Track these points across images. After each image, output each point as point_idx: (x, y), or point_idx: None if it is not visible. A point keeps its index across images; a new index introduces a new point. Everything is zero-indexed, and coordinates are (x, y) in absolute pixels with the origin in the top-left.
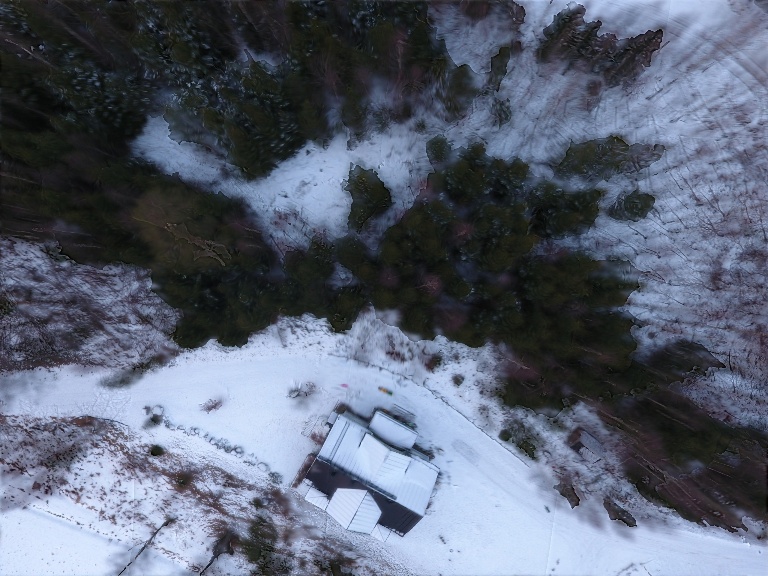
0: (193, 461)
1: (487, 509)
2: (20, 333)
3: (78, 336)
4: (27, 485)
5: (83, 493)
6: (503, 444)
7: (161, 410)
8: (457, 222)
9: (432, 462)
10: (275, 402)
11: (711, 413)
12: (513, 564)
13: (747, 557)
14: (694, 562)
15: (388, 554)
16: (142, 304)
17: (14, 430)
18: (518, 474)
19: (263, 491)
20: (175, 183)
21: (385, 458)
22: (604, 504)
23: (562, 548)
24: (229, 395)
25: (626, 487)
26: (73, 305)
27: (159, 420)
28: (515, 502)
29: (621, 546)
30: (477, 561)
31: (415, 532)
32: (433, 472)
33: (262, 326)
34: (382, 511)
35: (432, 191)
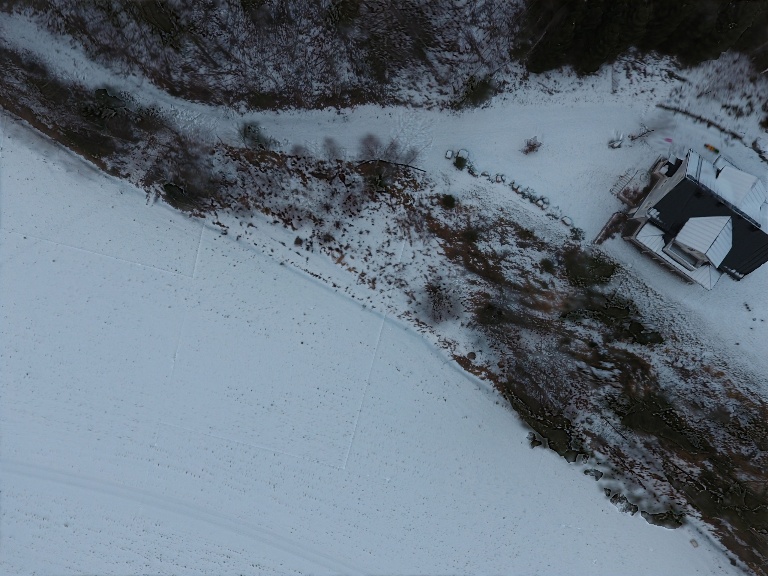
0: (486, 215)
1: None
2: (328, 59)
3: (391, 66)
4: (289, 239)
5: (348, 251)
6: None
7: (467, 154)
8: None
9: None
10: (592, 152)
11: None
12: None
13: None
14: None
15: (682, 321)
16: (479, 27)
17: (289, 176)
18: None
19: (555, 252)
20: None
21: (753, 185)
22: None
23: None
24: (543, 142)
25: None
26: (400, 26)
27: (462, 165)
28: None
29: None
30: None
31: (720, 297)
32: None
33: (636, 40)
34: (733, 245)
35: None
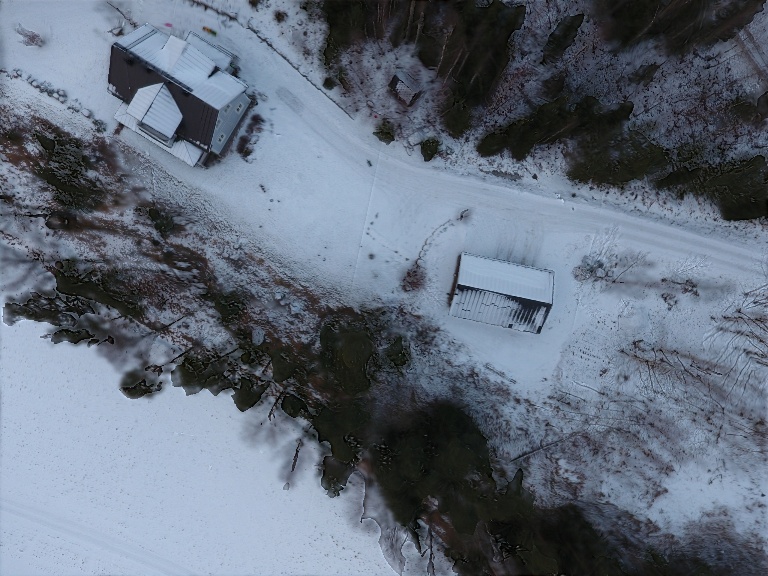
0: (20, 113)
1: (309, 159)
2: None
3: None
4: None
5: None
6: (327, 93)
7: None
8: None
9: (255, 109)
10: (98, 41)
11: (528, 53)
12: (332, 215)
13: (561, 214)
14: (509, 218)
15: (211, 208)
16: None
17: None
18: (342, 126)
19: (91, 148)
20: None
21: (183, 50)
22: (421, 150)
23: (382, 202)
24: (52, 35)
25: (447, 141)
26: None
27: None
28: (337, 154)
29: (440, 202)
30: (296, 211)
31: (236, 180)
32: (240, 86)
33: None
34: (183, 114)
35: None
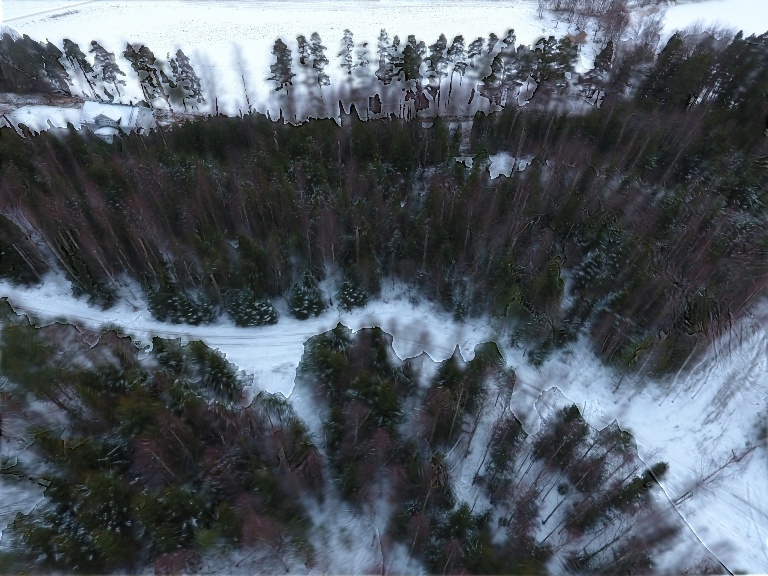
0: None
1: None
2: None
3: None
4: None
5: None
6: None
7: None
8: (35, 150)
9: None
10: None
11: None
12: (50, 119)
13: None
14: None
15: None
16: None
17: None
18: None
19: None
20: (205, 141)
21: (104, 112)
22: None
23: None
24: None
25: None
26: None
27: None
28: None
29: None
30: (71, 118)
31: None
32: (83, 120)
33: None
34: None
35: (51, 166)
